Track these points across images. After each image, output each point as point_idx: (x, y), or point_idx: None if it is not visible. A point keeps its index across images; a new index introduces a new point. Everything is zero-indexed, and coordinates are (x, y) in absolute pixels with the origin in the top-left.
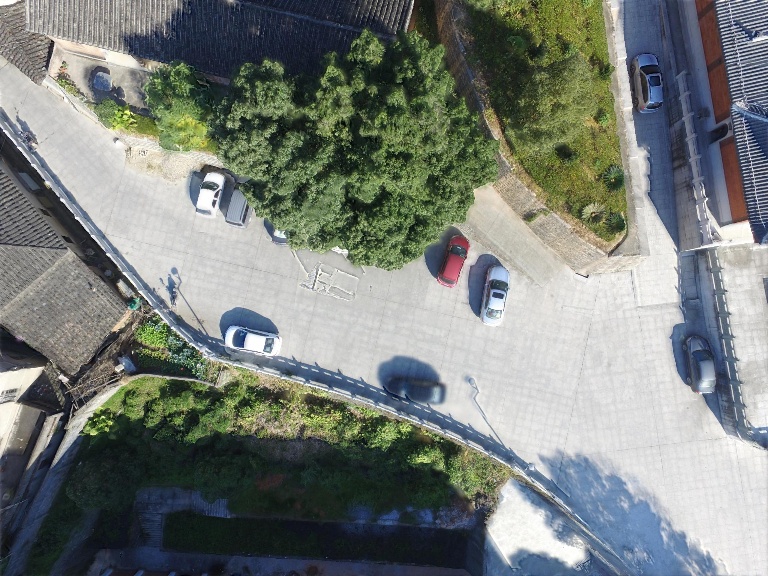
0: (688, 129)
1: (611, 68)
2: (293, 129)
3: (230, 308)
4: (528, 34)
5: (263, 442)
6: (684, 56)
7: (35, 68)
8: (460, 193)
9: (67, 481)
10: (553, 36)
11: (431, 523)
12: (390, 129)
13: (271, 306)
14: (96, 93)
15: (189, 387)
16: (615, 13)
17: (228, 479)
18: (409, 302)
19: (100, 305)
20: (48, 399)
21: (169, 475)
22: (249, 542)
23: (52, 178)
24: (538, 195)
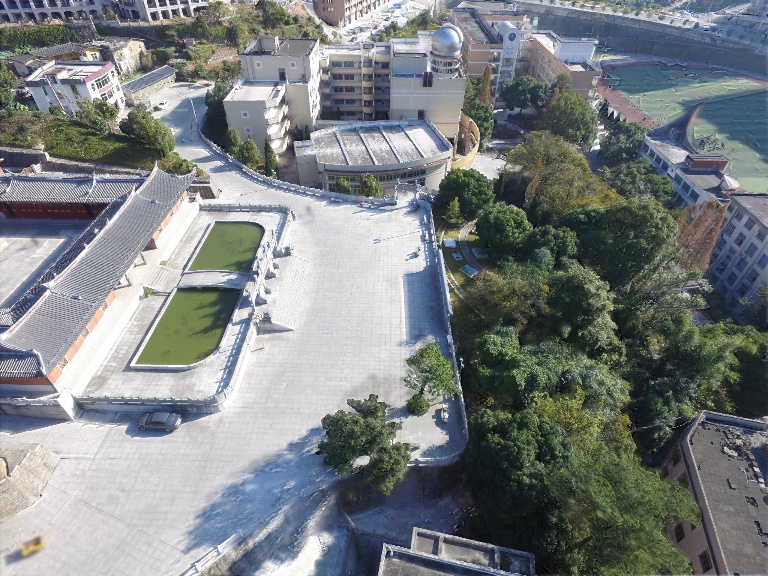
0: None
1: None
2: None
3: None
4: None
5: None
6: None
7: None
8: None
9: None
10: None
11: None
12: None
13: None
14: None
15: None
16: None
17: None
18: None
19: None
20: None
21: None
22: None
23: None
24: None
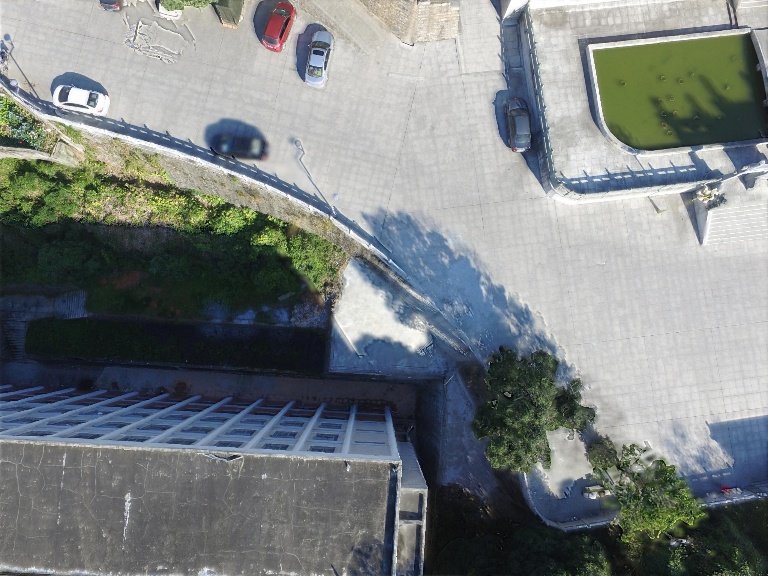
0: None
1: None
2: None
3: (61, 73)
4: None
5: (112, 230)
6: None
7: None
8: None
9: None
10: None
11: (287, 322)
12: None
13: (102, 71)
14: None
15: None
16: None
17: (72, 259)
18: (238, 68)
19: None
20: None
21: (26, 274)
22: (109, 346)
23: None
24: None
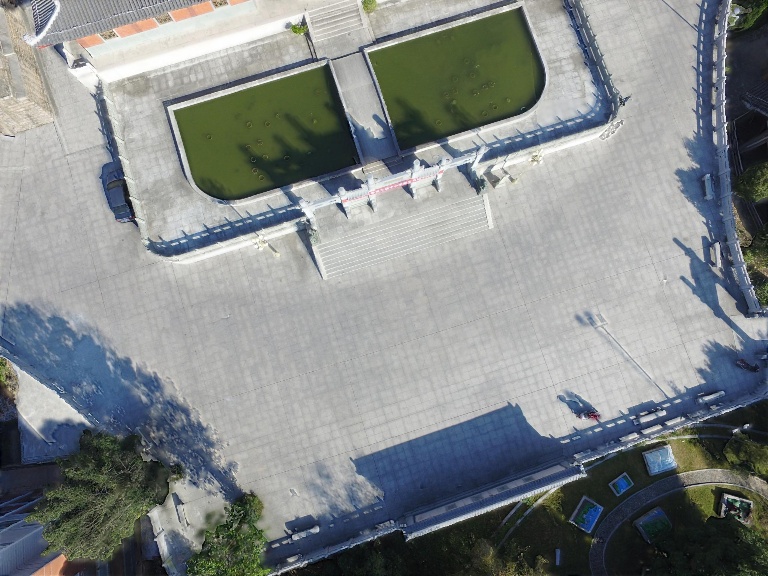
0: None
1: None
2: None
3: None
4: None
5: None
6: None
7: None
8: None
9: None
10: None
11: None
12: None
13: None
14: None
15: None
16: None
17: None
18: None
19: None
20: None
21: None
22: None
23: None
24: None
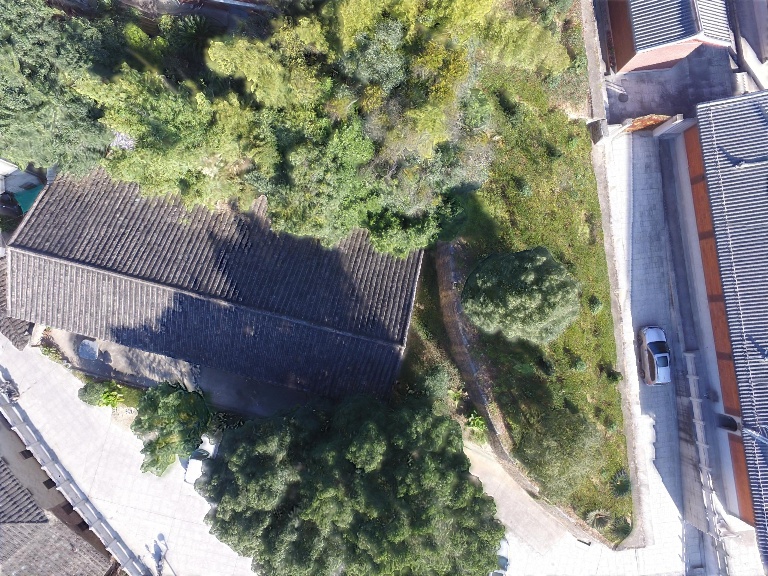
0: (696, 412)
1: (619, 379)
2: (287, 513)
3: None
4: (534, 346)
5: None
6: (692, 328)
7: (17, 334)
8: None
9: None
10: (560, 350)
11: None
12: (390, 569)
13: None
14: (81, 357)
15: None
16: (623, 293)
17: None
18: None
19: (82, 564)
20: None
21: None
22: None
23: (34, 433)
24: None
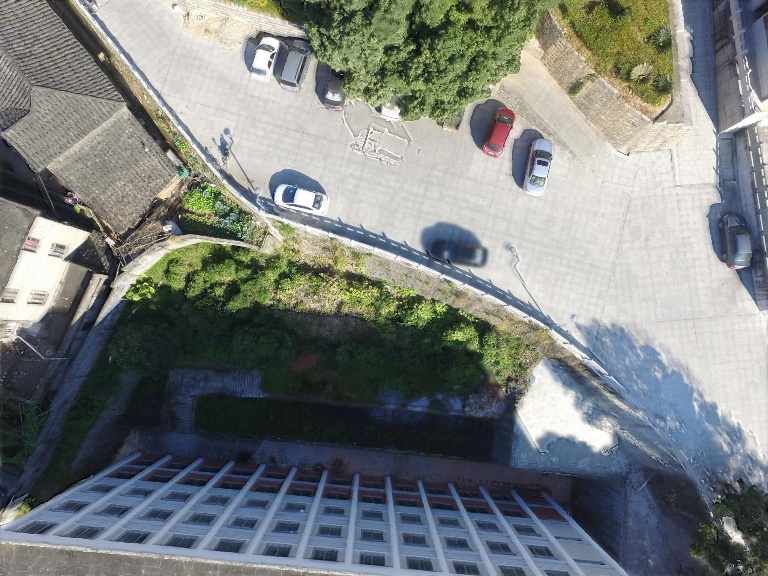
0: (733, 7)
1: None
2: None
3: (280, 169)
4: None
5: (301, 317)
6: None
7: None
8: (527, 9)
9: (106, 348)
10: None
11: (460, 411)
12: None
13: (320, 169)
14: None
15: (231, 258)
16: None
17: (267, 347)
18: (454, 171)
19: (151, 166)
20: (93, 263)
21: (205, 352)
22: (279, 425)
23: (111, 39)
24: (587, 59)
